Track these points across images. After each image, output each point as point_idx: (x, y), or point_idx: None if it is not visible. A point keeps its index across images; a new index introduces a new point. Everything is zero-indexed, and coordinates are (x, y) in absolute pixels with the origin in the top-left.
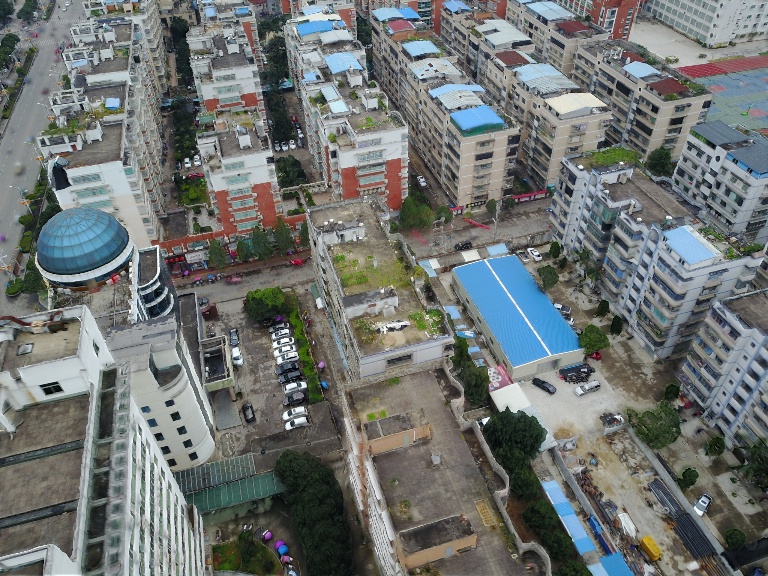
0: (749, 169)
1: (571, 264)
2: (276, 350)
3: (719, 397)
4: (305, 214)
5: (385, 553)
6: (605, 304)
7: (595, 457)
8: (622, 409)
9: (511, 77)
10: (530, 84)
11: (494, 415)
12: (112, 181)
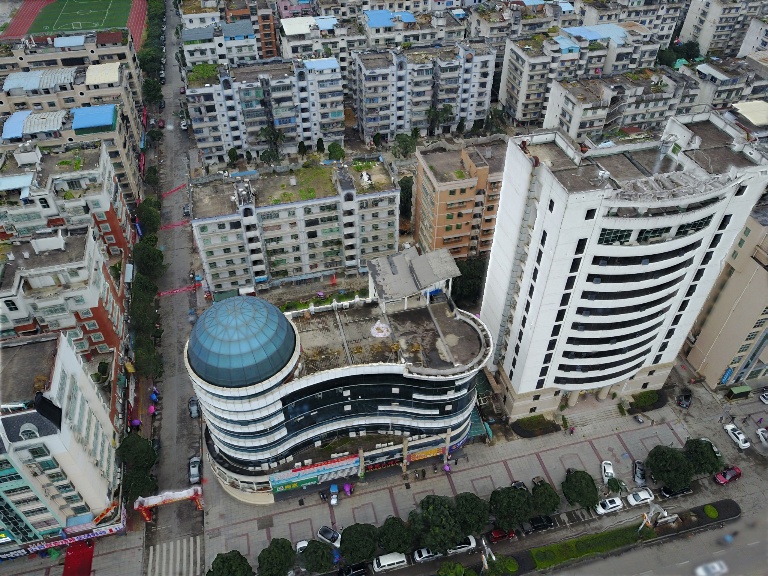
0: (245, 36)
1: (239, 161)
2: None
3: (391, 119)
4: (122, 279)
5: None
6: (303, 143)
7: None
8: None
9: (7, 98)
10: (47, 86)
11: None
12: (69, 368)
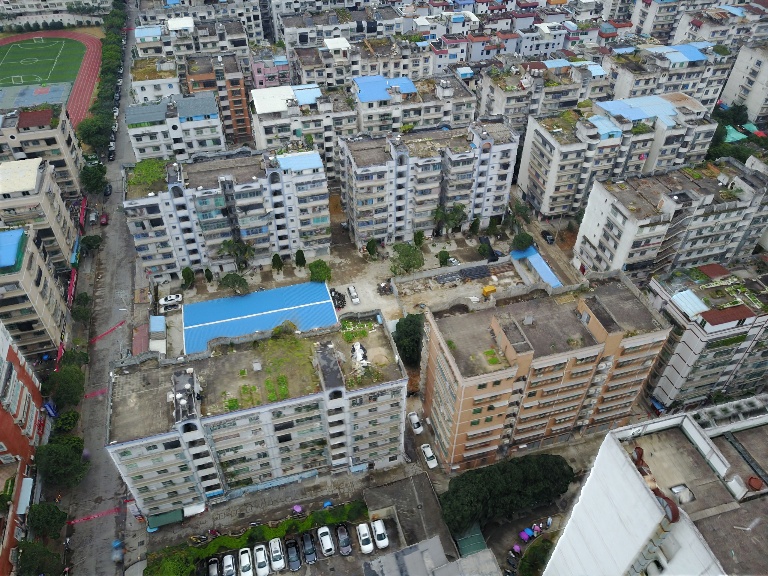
0: (206, 116)
1: (197, 277)
2: (258, 572)
3: (389, 221)
4: (11, 514)
5: (570, 395)
6: (278, 256)
7: (418, 304)
8: (373, 282)
9: None
10: None
11: (402, 341)
12: None
